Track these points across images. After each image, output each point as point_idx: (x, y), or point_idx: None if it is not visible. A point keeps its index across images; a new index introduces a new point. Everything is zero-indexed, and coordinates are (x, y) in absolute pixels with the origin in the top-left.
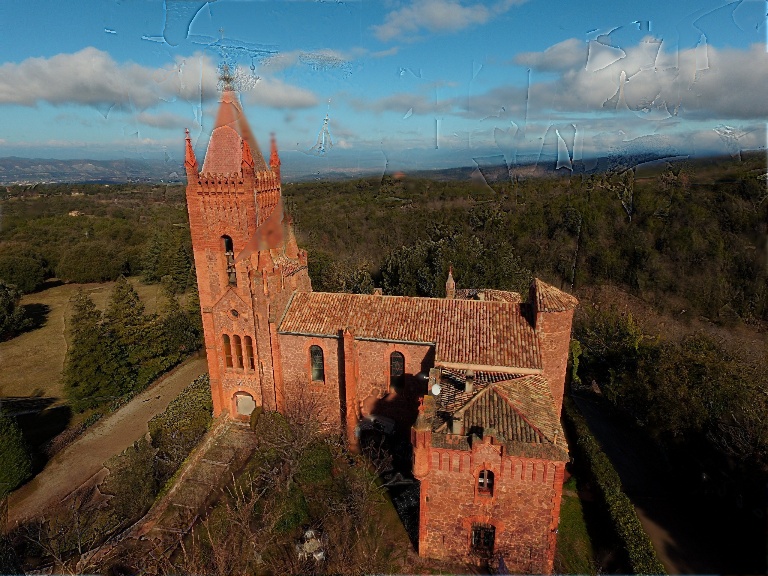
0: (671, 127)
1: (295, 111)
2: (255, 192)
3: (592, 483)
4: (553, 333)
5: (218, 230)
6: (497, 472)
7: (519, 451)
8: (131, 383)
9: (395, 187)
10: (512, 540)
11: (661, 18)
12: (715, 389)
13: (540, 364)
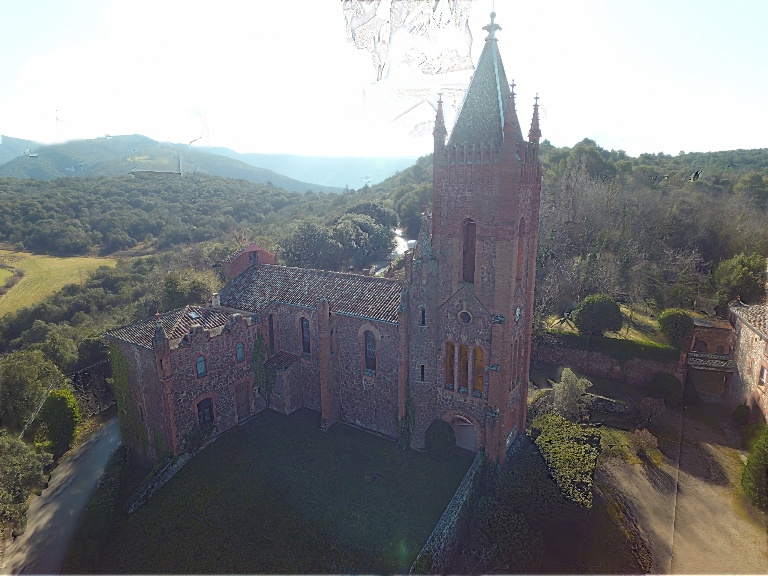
0: None
1: None
2: None
3: None
4: None
5: None
6: None
7: None
8: None
9: None
10: None
11: None
12: None
13: None
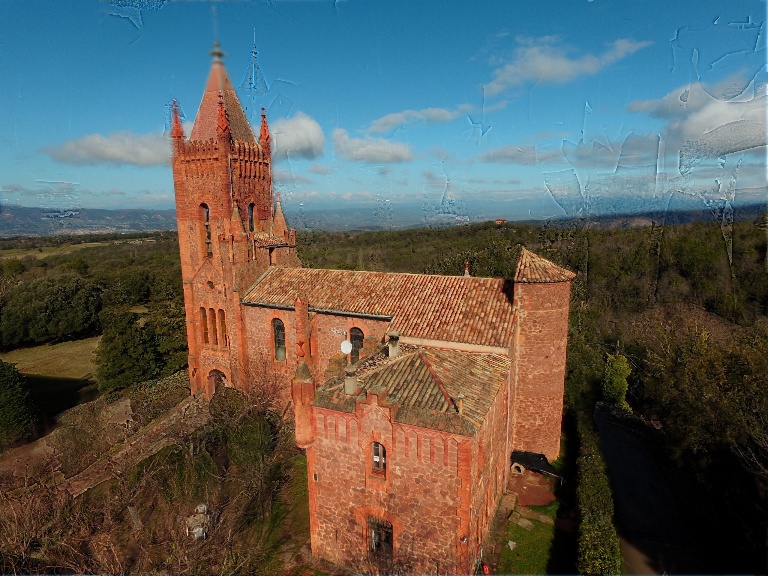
0: (764, 110)
1: (216, 40)
2: (229, 158)
3: (576, 509)
4: (536, 311)
5: (197, 198)
6: (388, 446)
7: (412, 418)
8: (156, 370)
9: (456, 207)
10: (414, 547)
11: (764, 3)
12: (761, 392)
13: (506, 342)
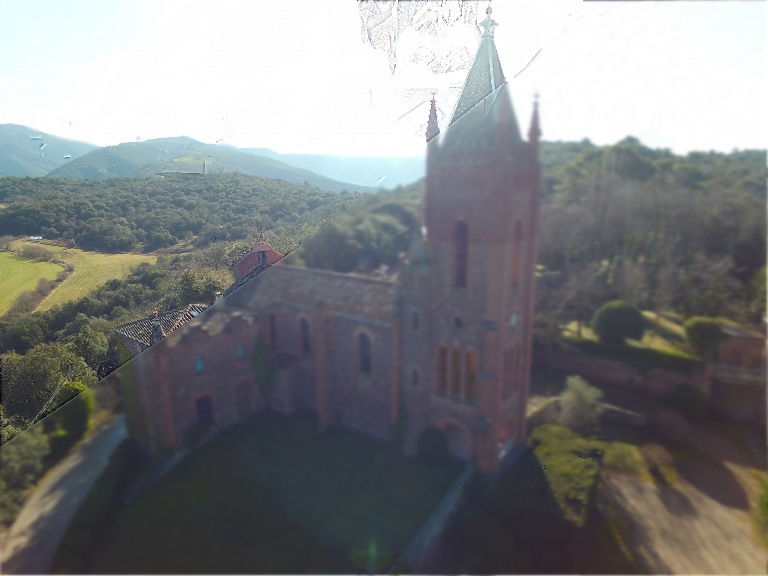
0: None
1: None
2: None
3: None
4: None
5: None
6: None
7: None
8: None
9: None
10: None
11: None
12: None
13: None
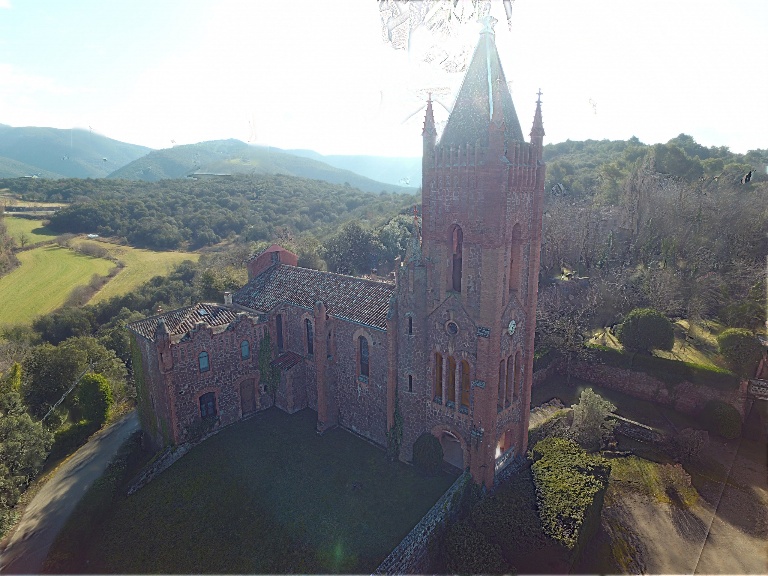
0: None
1: None
2: None
3: None
4: None
5: None
6: None
7: None
8: None
9: None
10: None
11: None
12: None
13: None
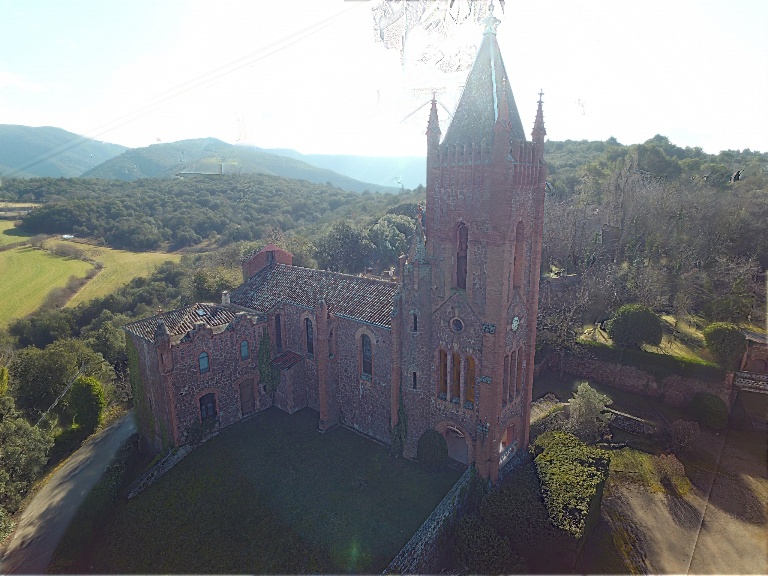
0: None
1: None
2: None
3: None
4: None
5: None
6: None
7: None
8: None
9: None
10: None
11: None
12: None
13: None
